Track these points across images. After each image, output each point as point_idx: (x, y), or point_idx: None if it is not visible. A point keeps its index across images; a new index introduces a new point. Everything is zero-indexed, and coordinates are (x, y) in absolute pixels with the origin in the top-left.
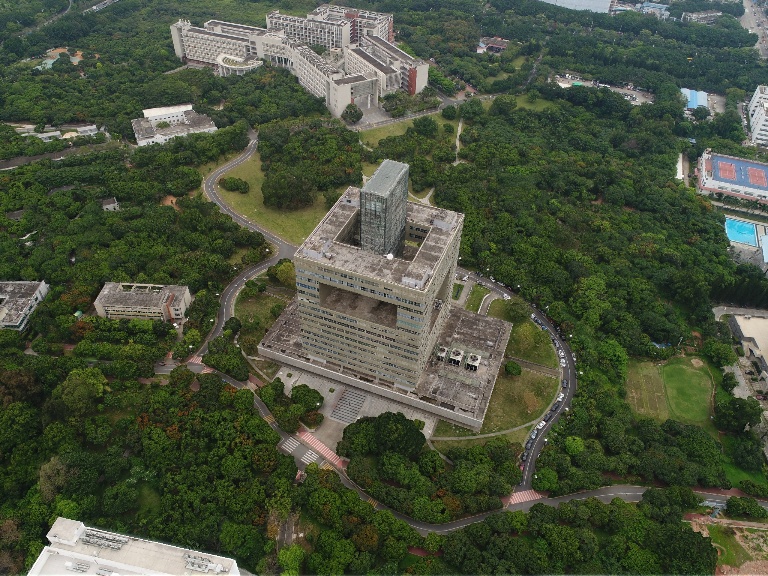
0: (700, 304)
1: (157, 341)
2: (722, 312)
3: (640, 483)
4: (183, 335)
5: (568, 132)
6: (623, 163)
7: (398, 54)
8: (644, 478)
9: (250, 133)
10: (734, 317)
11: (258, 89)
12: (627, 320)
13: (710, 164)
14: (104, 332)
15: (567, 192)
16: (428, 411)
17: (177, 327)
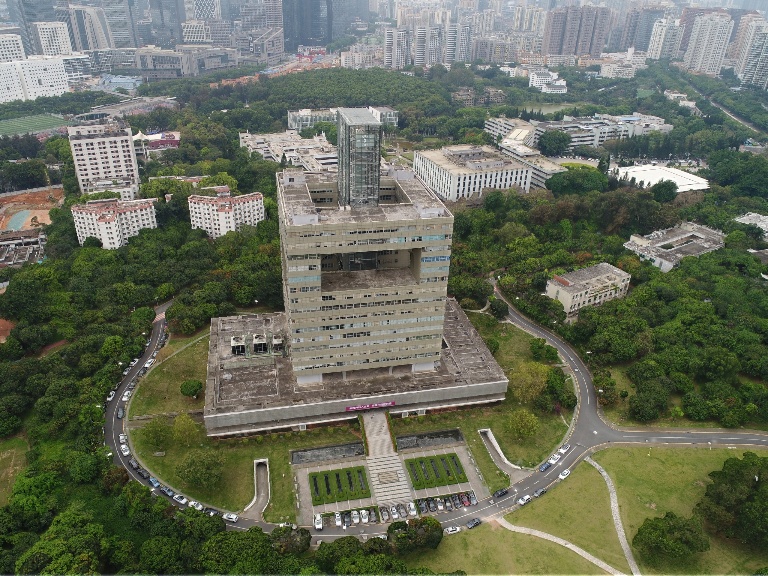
0: None
1: None
2: None
3: None
4: None
5: None
6: None
7: None
8: None
9: None
10: None
11: None
12: None
13: None
14: None
15: None
16: None
17: None
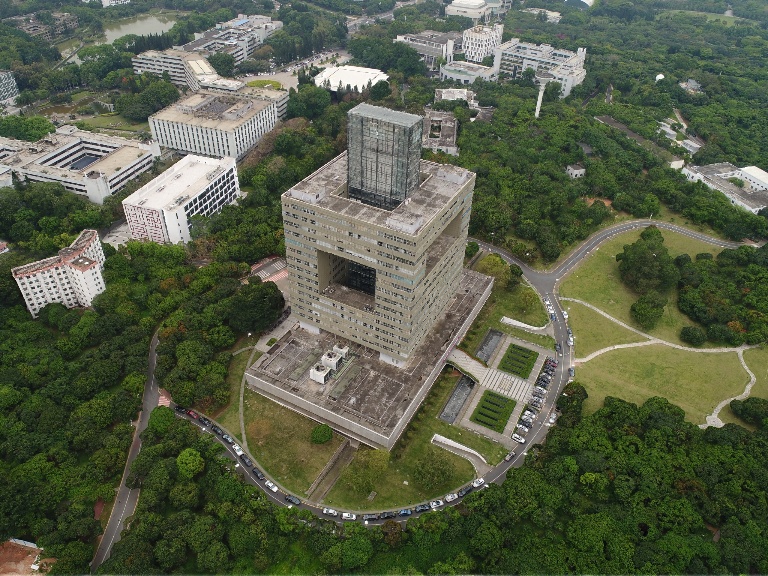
0: None
1: None
2: None
3: None
4: None
5: None
6: None
7: None
8: None
9: None
10: None
11: None
12: None
13: None
14: None
15: None
16: None
17: None
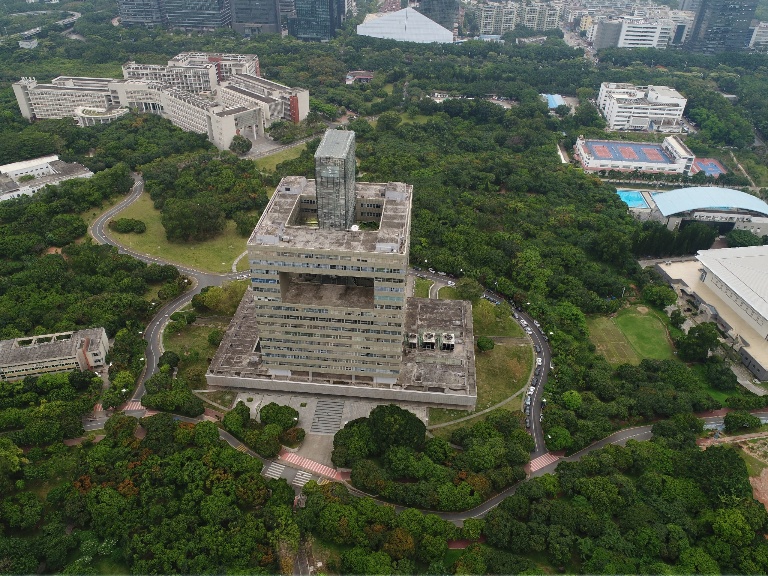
0: (626, 259)
1: (78, 395)
2: (644, 265)
3: (642, 423)
4: (109, 382)
5: (454, 139)
6: (513, 157)
7: (274, 86)
8: (645, 416)
9: (132, 176)
10: (658, 265)
11: (131, 133)
12: (572, 281)
13: (586, 148)
14: (4, 398)
15: (473, 187)
16: (416, 401)
17: (99, 376)
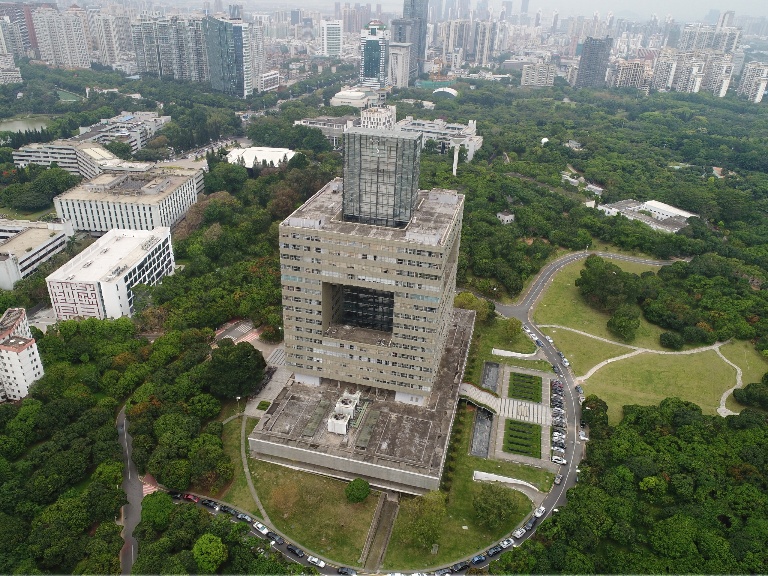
0: None
1: None
2: None
3: None
4: None
5: None
6: None
7: None
8: None
9: None
10: None
11: None
12: None
13: None
14: None
15: None
16: None
17: None
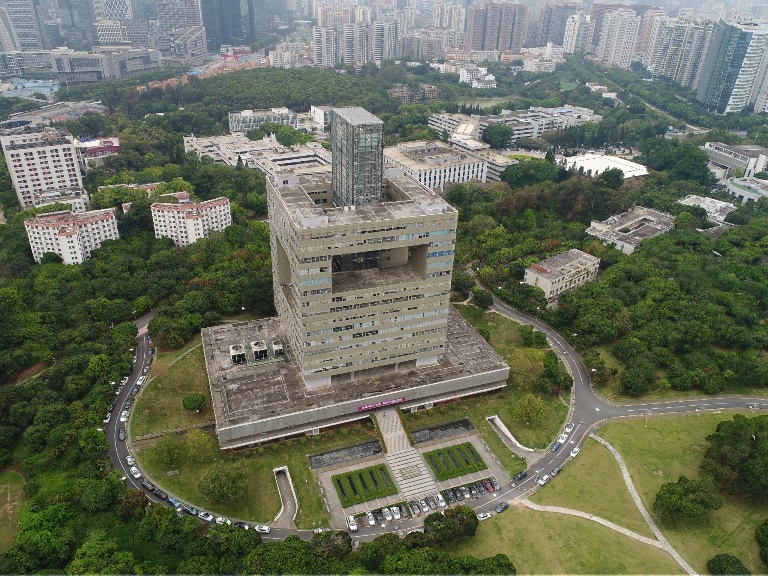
0: None
1: None
2: None
3: None
4: None
5: None
6: None
7: None
8: None
9: None
10: None
11: None
12: None
13: None
14: None
15: None
16: None
17: None
